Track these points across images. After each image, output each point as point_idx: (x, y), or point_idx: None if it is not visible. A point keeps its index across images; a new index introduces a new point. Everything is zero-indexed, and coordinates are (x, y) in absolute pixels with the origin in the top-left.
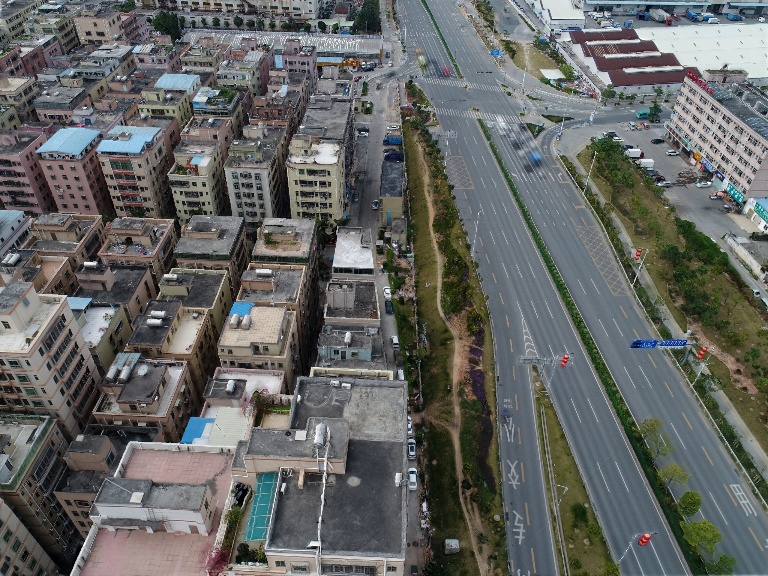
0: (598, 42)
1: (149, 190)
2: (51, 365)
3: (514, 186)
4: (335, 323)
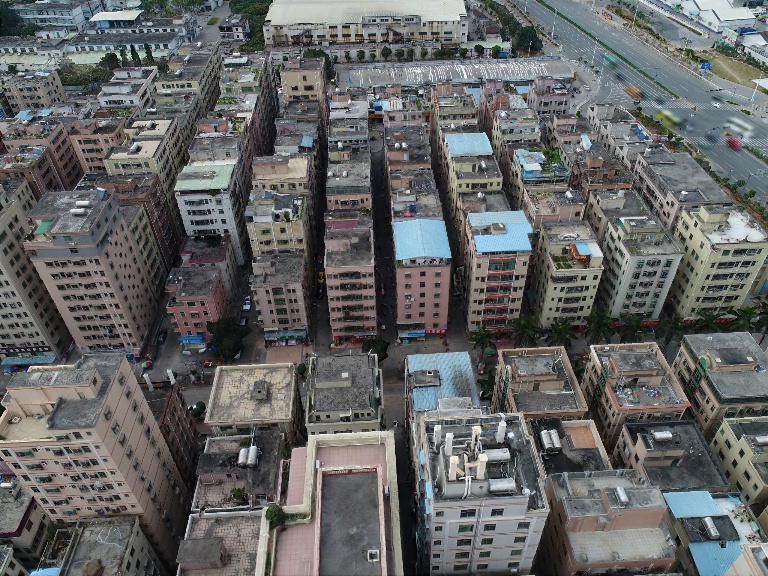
0: None
1: (523, 289)
2: None
3: None
4: None
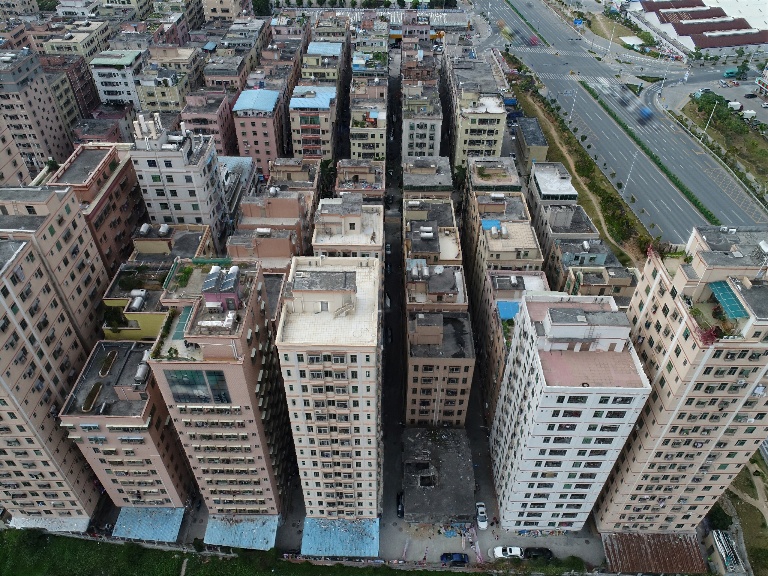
0: (671, 10)
1: (330, 143)
2: (381, 261)
3: (636, 136)
4: (559, 238)
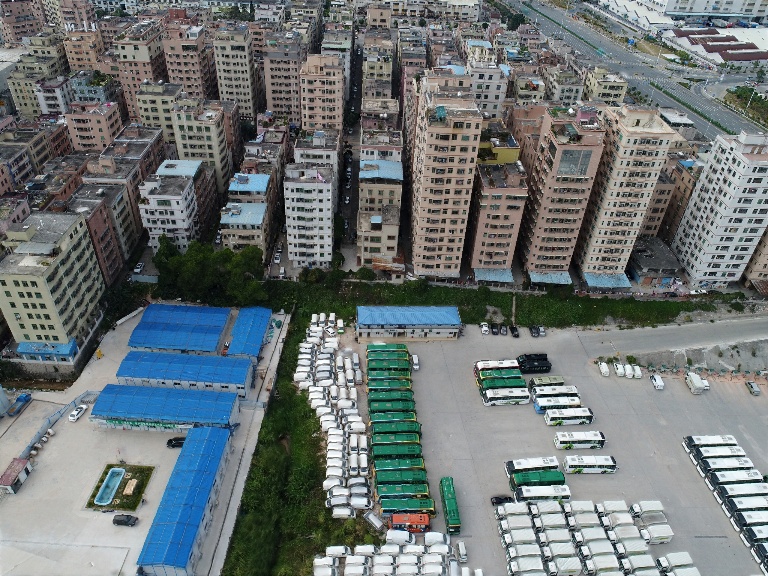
0: (698, 36)
1: None
2: None
3: (699, 111)
4: None
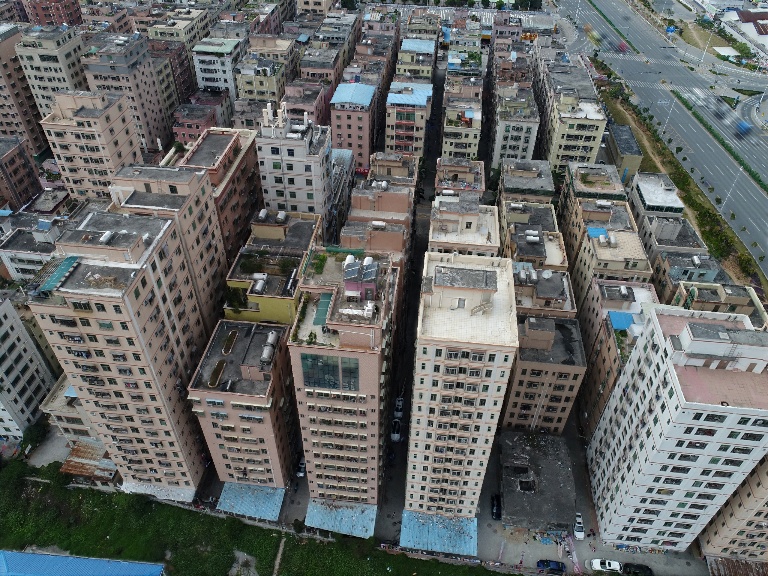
0: None
1: (422, 140)
2: None
3: (734, 151)
4: (665, 251)
